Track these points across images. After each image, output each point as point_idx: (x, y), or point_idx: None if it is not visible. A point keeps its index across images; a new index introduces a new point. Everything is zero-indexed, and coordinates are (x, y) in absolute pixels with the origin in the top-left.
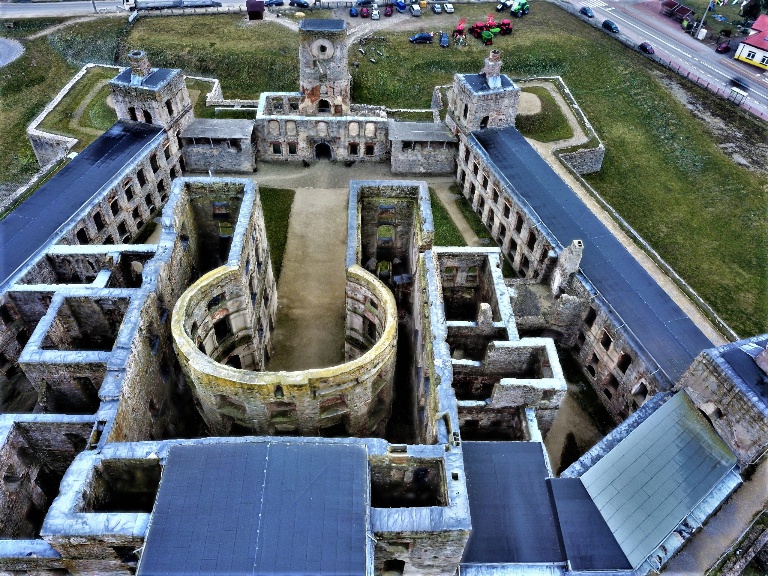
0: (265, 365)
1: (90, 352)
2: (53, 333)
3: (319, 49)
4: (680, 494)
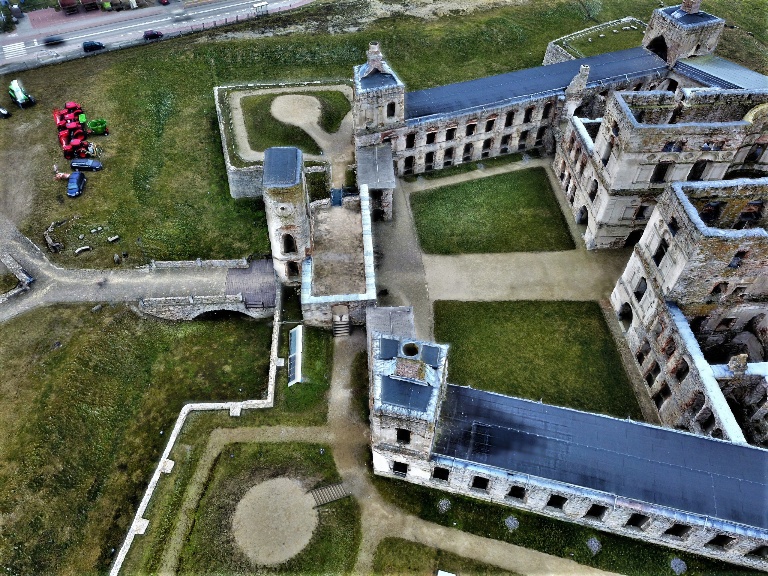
0: None
1: None
2: None
3: None
4: (748, 72)
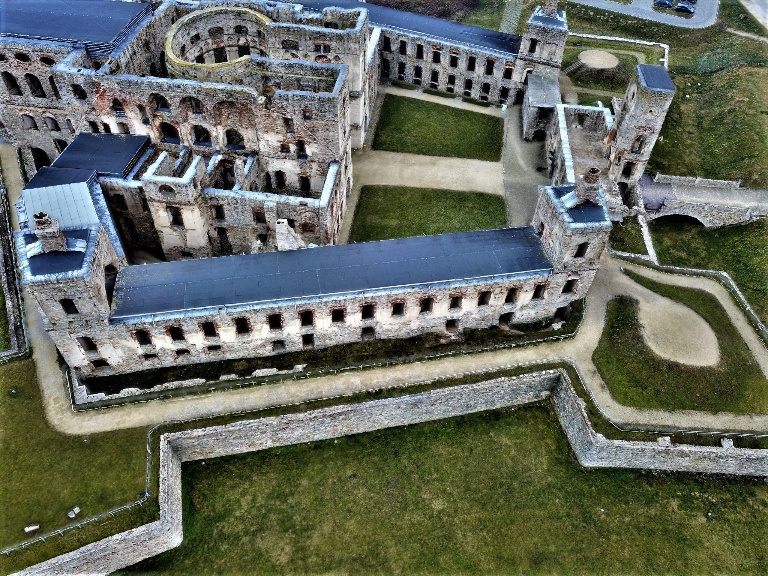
0: None
1: None
2: None
3: None
4: None
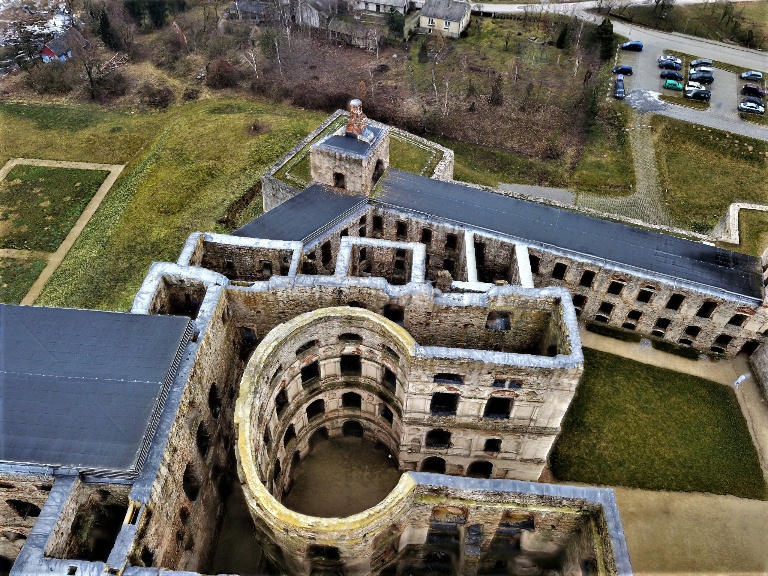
0: (433, 469)
1: (345, 274)
2: (378, 252)
3: None
4: None
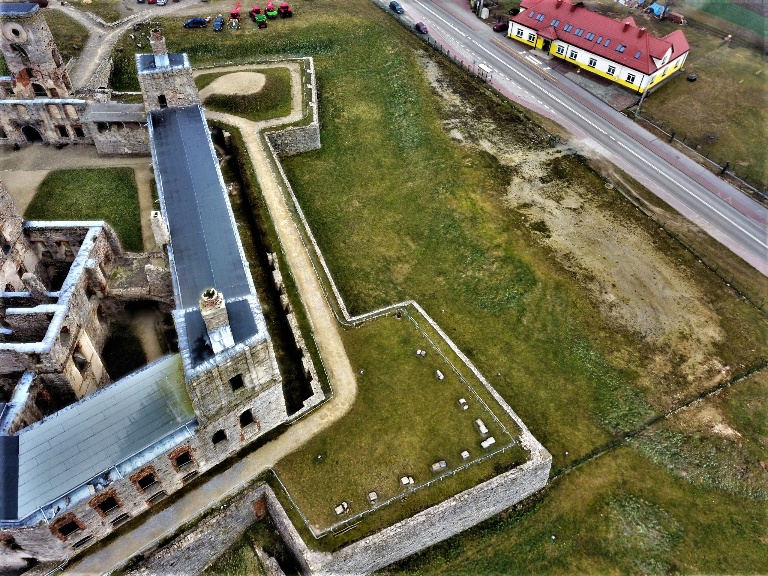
0: None
1: None
2: None
3: (12, 33)
4: (113, 449)
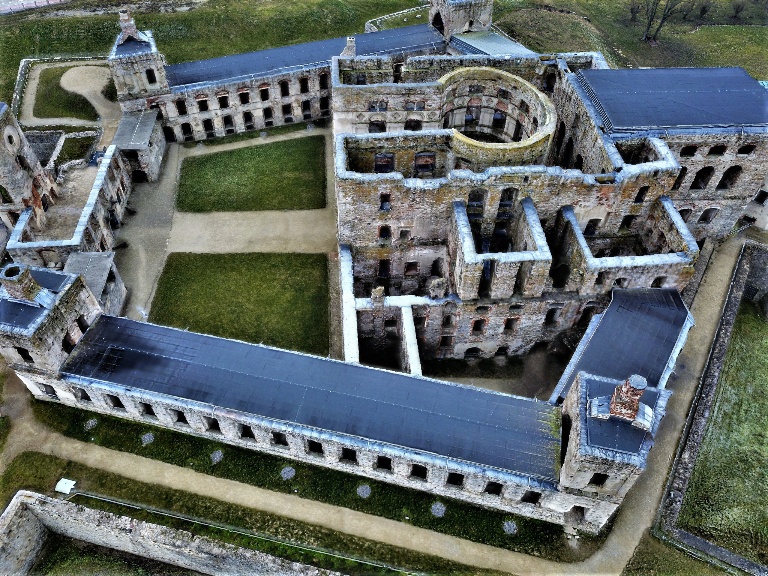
0: None
1: (530, 220)
2: None
3: (9, 143)
4: (514, 46)
